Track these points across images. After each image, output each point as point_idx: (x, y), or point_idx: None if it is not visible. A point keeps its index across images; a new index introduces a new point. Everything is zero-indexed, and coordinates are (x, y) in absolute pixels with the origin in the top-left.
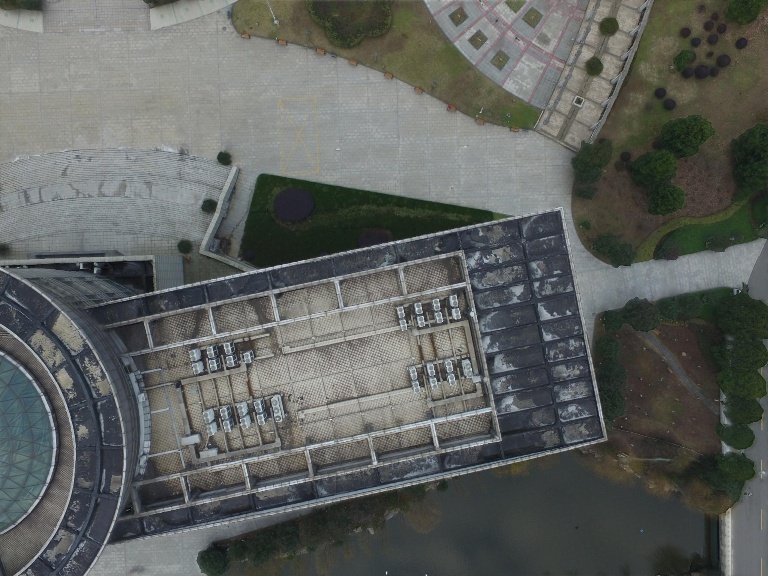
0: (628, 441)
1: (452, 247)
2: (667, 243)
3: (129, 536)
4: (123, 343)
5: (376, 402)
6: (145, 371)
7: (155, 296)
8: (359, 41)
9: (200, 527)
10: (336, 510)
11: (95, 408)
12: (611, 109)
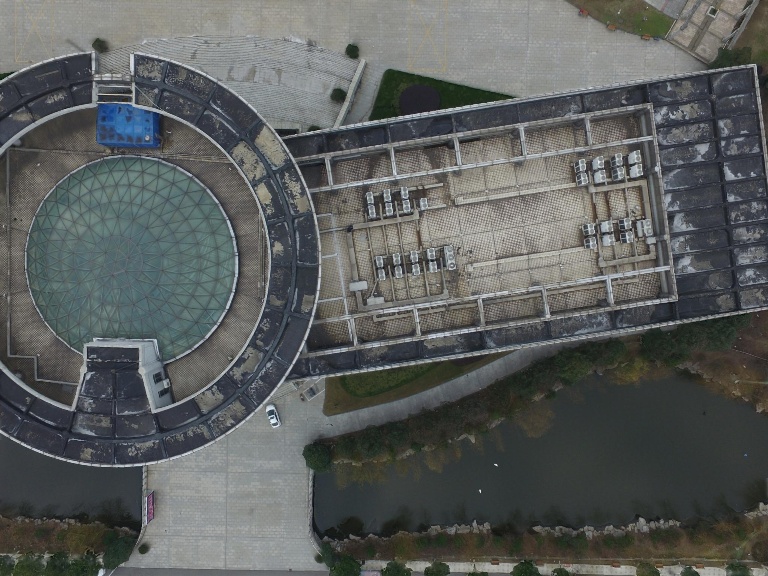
0: (740, 362)
1: (639, 101)
2: None
3: (294, 377)
4: None
5: (545, 260)
6: None
7: (336, 134)
8: None
9: (370, 369)
10: (449, 409)
11: (293, 224)
12: None
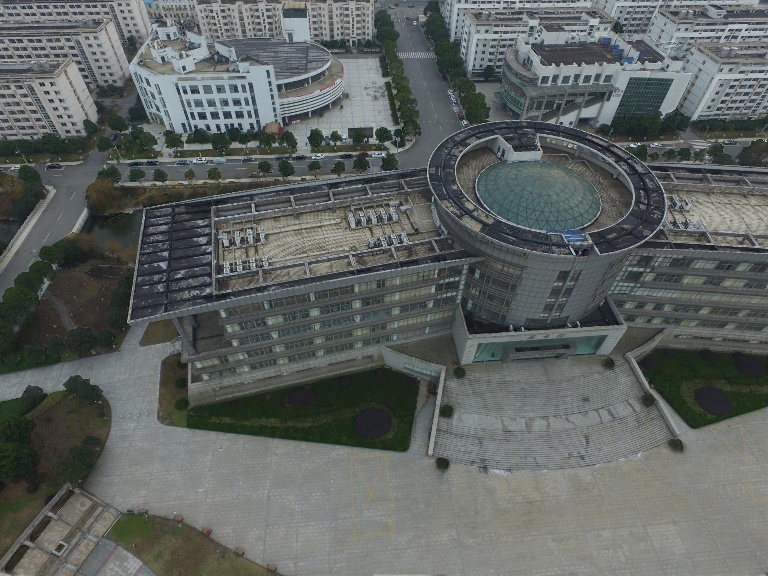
0: None
1: (221, 299)
2: (31, 399)
3: None
4: None
5: None
6: None
7: None
8: None
9: (393, 171)
10: None
11: None
12: None
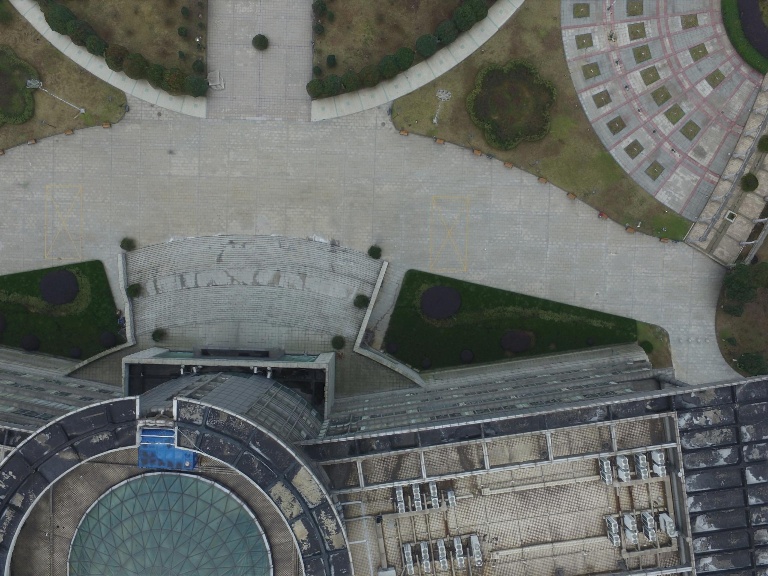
0: None
1: (663, 406)
2: None
3: None
4: (327, 474)
5: (569, 547)
6: (345, 502)
7: None
8: (516, 144)
9: None
10: None
11: (328, 561)
12: (762, 225)
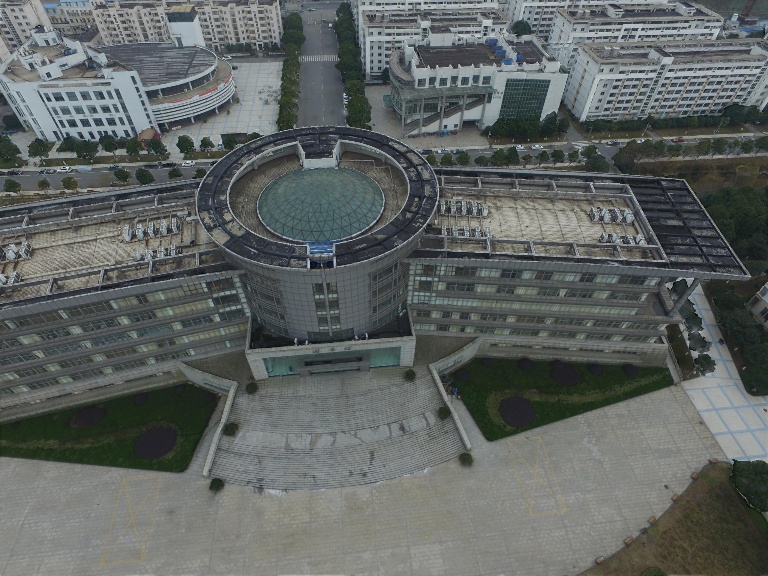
0: None
1: None
2: None
3: None
4: None
5: None
6: None
7: None
8: None
9: None
10: None
11: None
12: None
